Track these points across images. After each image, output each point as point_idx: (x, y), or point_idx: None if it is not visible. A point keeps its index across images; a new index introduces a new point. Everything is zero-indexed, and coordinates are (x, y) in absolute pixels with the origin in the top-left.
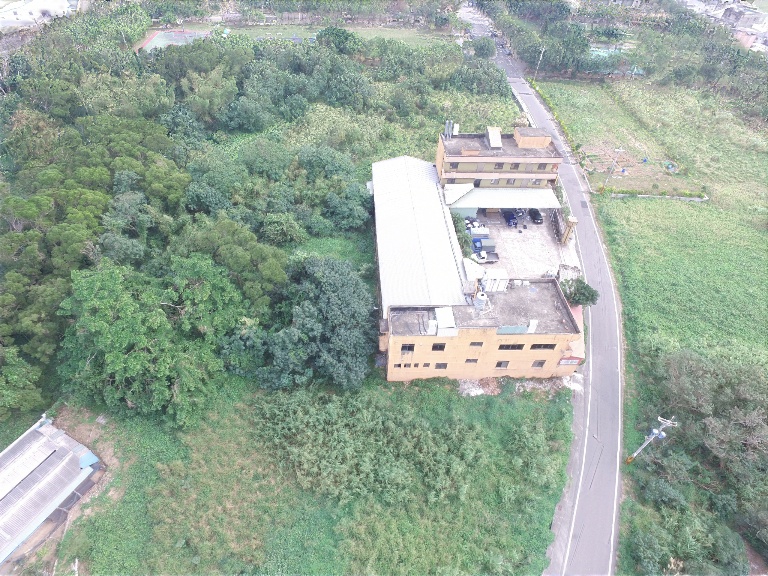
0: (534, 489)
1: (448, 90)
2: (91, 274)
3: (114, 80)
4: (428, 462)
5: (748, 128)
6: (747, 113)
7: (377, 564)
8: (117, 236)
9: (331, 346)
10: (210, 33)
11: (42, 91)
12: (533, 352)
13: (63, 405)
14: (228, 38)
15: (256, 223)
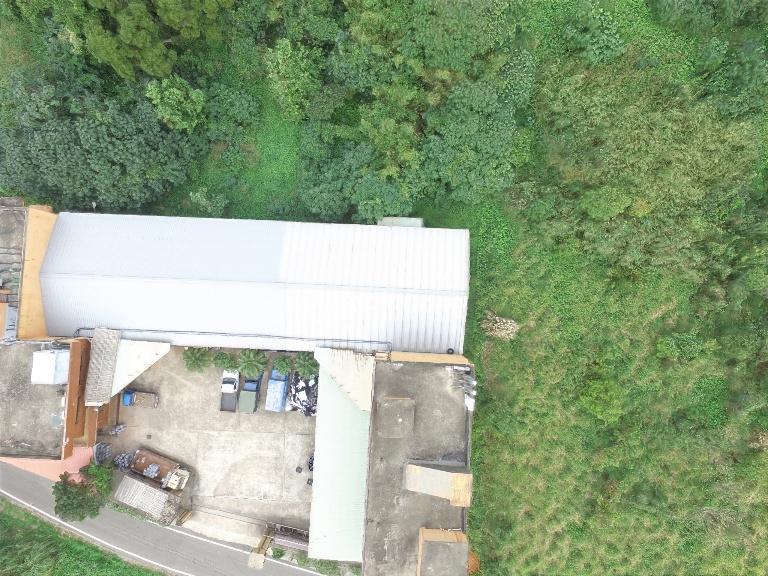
0: None
1: None
2: None
3: None
4: None
5: None
6: None
7: None
8: None
9: None
10: None
11: None
12: None
13: None
14: None
15: None
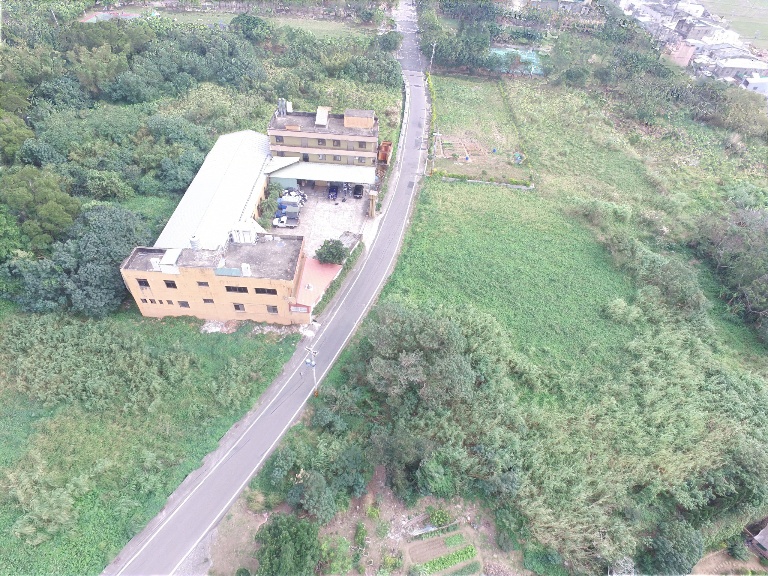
0: (219, 409)
1: (340, 78)
2: None
3: (6, 49)
4: (135, 379)
5: (622, 129)
6: (625, 115)
7: (52, 453)
8: None
9: (76, 276)
10: (141, 16)
11: None
12: (260, 296)
13: None
14: None
15: None
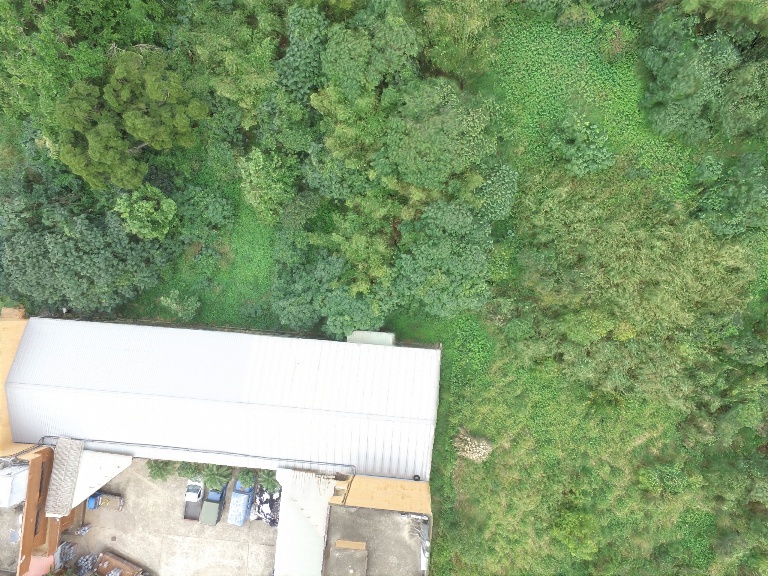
0: None
1: None
2: None
3: None
4: None
5: None
6: None
7: None
8: None
9: None
10: None
11: None
12: None
13: None
14: None
15: None
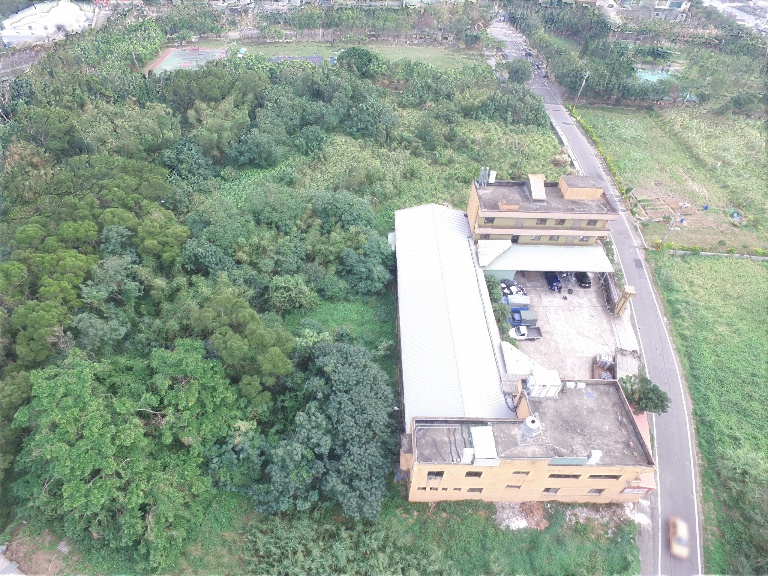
0: None
1: (479, 119)
2: (56, 373)
3: (115, 111)
4: None
5: None
6: None
7: None
8: (94, 317)
9: (341, 468)
10: (225, 52)
11: (38, 123)
12: (591, 481)
13: (21, 525)
14: (244, 59)
15: (261, 285)
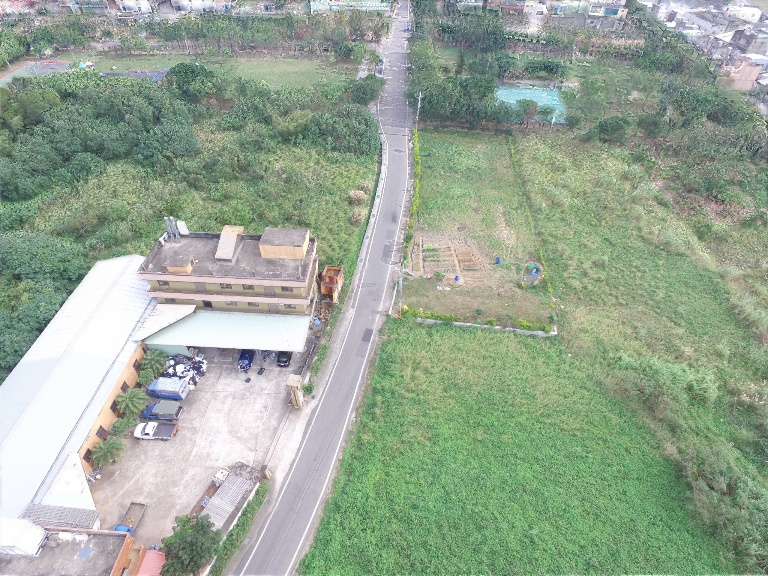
0: None
1: (297, 145)
2: None
3: None
4: None
5: (682, 208)
6: (685, 186)
7: None
8: None
9: None
10: (69, 66)
11: None
12: None
13: None
14: (73, 74)
15: None
